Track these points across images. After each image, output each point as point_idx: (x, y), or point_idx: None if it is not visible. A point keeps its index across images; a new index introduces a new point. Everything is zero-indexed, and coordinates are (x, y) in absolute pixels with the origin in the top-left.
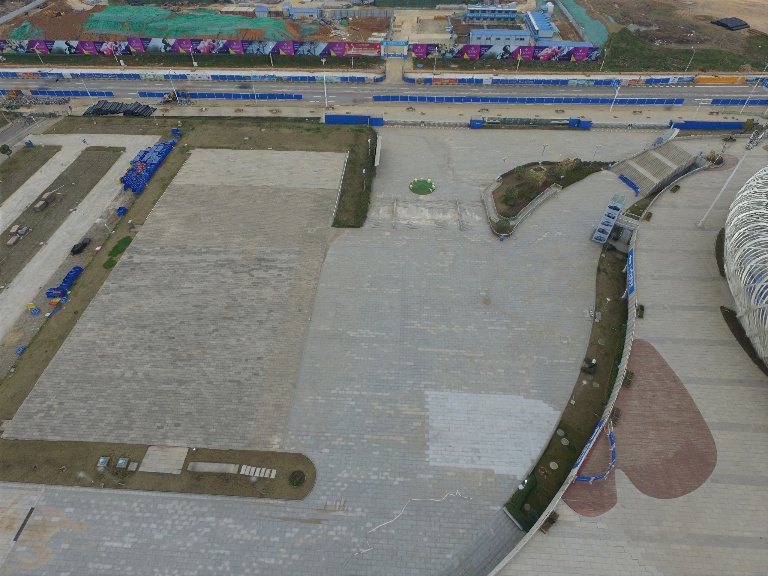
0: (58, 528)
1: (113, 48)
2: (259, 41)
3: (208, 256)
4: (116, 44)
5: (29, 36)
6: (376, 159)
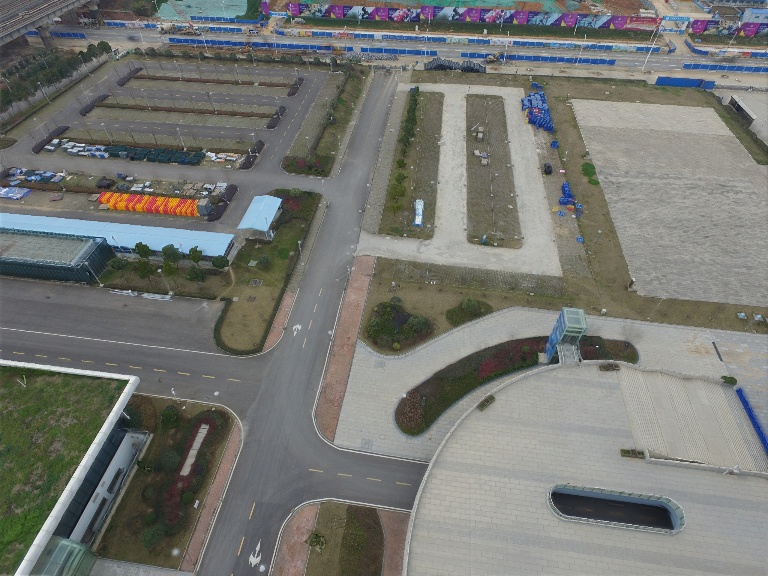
0: (748, 356)
1: (404, 15)
2: (546, 12)
3: (673, 180)
4: (409, 11)
5: (318, 2)
6: (750, 113)
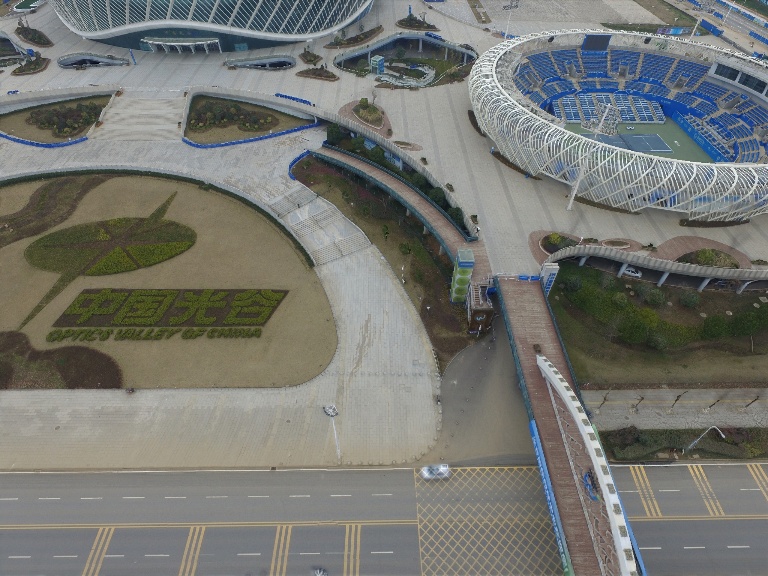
0: (459, 4)
1: None
2: None
3: None
4: None
5: None
6: None
